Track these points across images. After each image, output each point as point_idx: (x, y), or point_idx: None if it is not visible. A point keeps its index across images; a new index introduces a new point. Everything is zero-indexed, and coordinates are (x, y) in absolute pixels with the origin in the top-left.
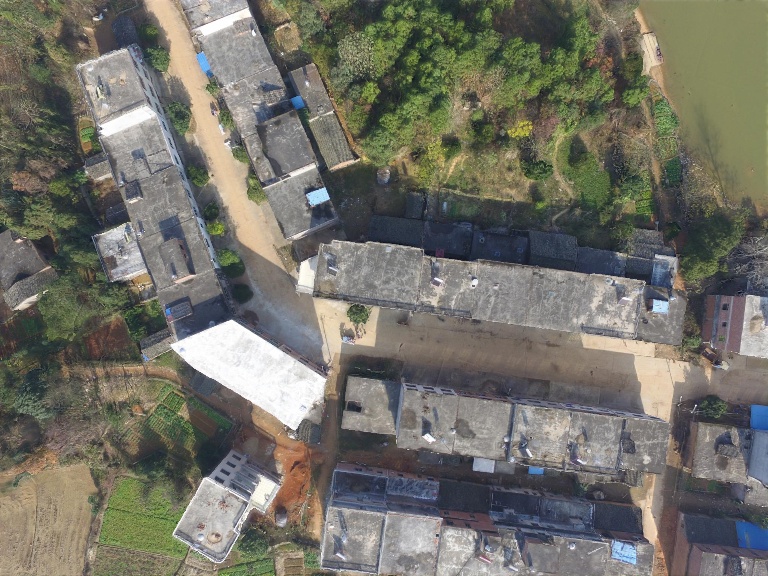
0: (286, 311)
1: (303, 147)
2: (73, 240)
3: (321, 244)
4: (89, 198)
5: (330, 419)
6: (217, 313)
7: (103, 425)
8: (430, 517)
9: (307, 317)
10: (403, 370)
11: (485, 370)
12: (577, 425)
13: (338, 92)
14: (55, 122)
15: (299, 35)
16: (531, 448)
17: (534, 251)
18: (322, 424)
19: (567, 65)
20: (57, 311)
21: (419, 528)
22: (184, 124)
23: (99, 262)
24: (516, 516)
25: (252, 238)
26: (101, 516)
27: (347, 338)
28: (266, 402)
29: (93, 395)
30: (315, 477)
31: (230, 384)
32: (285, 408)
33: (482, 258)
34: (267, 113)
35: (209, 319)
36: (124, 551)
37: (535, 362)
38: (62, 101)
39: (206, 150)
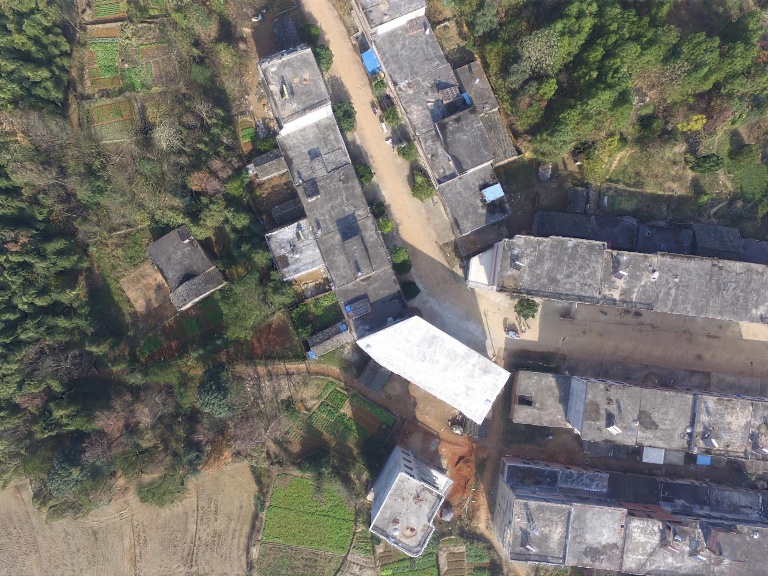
0: (450, 307)
1: (483, 143)
2: (244, 239)
3: (504, 239)
4: (251, 198)
5: (494, 413)
6: (395, 309)
7: (266, 423)
8: (615, 508)
9: (471, 313)
10: (566, 364)
11: (647, 362)
12: (758, 415)
13: (505, 89)
14: (225, 123)
15: (458, 33)
16: (713, 438)
17: (701, 243)
18: (487, 419)
19: (744, 58)
20: (239, 310)
21: (604, 519)
22: (351, 123)
23: (271, 261)
24: (690, 506)
25: (415, 235)
26: (263, 514)
27: (513, 333)
28: (451, 397)
29: (255, 394)
30: (480, 471)
31: (416, 379)
32: (470, 402)
33: (649, 251)
34: (441, 110)
35: (387, 316)
36: (287, 548)
37: (696, 354)
38: (220, 102)
39: (367, 148)
